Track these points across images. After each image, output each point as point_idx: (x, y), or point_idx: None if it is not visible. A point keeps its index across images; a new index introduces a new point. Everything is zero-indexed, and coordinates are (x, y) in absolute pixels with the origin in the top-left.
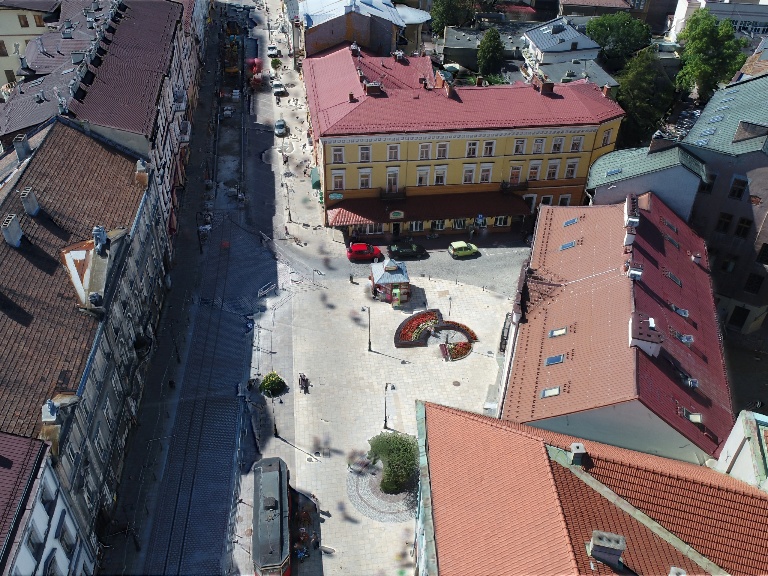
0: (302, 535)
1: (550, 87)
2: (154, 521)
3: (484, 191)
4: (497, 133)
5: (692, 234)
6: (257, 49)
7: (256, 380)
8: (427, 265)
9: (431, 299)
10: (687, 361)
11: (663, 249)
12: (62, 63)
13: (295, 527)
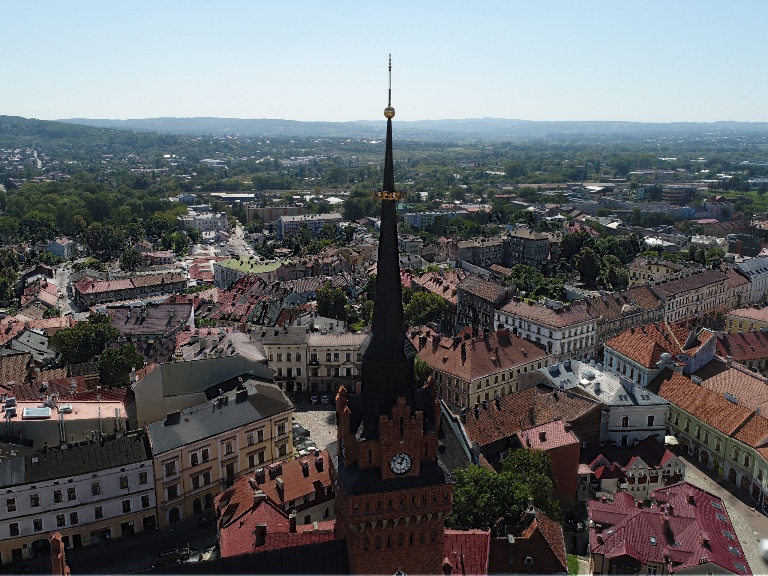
0: None
1: None
2: None
3: None
4: None
5: None
6: None
7: None
8: None
9: None
10: None
11: None
12: None
13: None
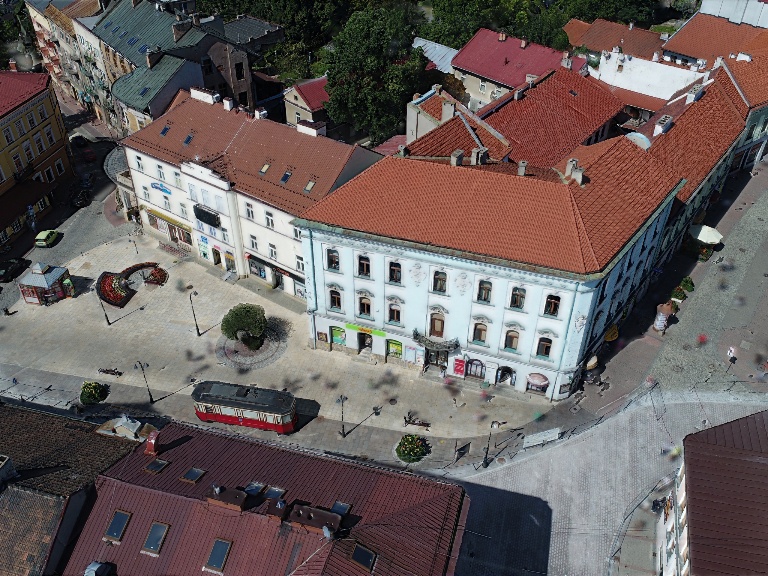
0: None
1: None
2: None
3: (6, 191)
4: None
5: None
6: None
7: (75, 405)
8: None
9: (86, 274)
10: None
11: None
12: None
13: None
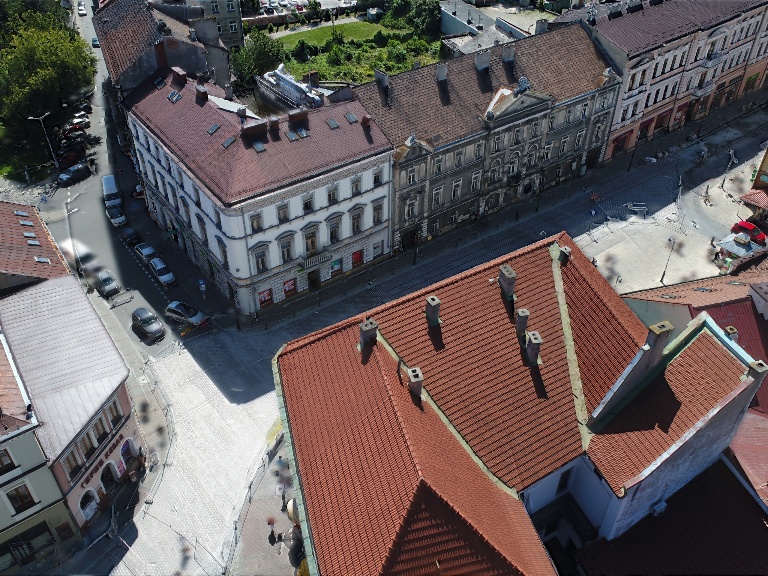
0: None
1: None
2: (434, 260)
3: None
4: None
5: None
6: None
7: None
8: None
9: None
10: None
11: None
12: None
13: None
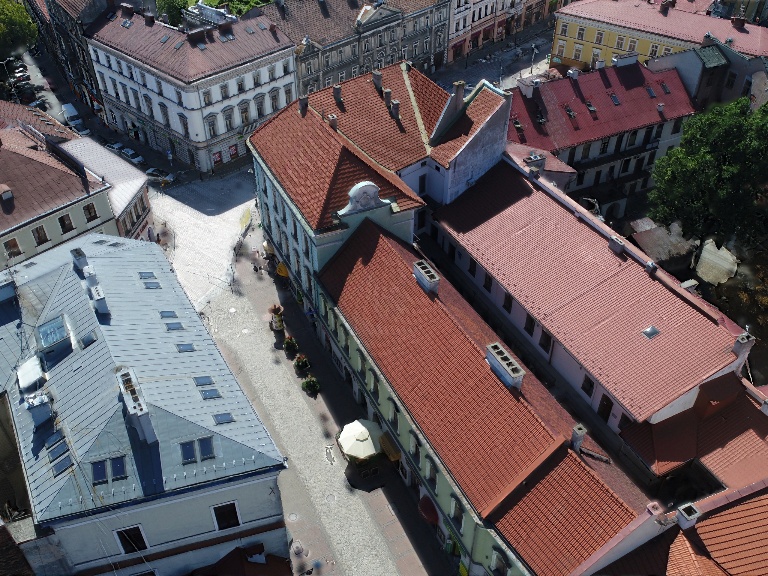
0: None
1: (742, 22)
2: None
3: None
4: (674, 42)
5: (686, 103)
6: None
7: None
8: None
9: None
10: (557, 118)
11: (631, 88)
12: None
13: None
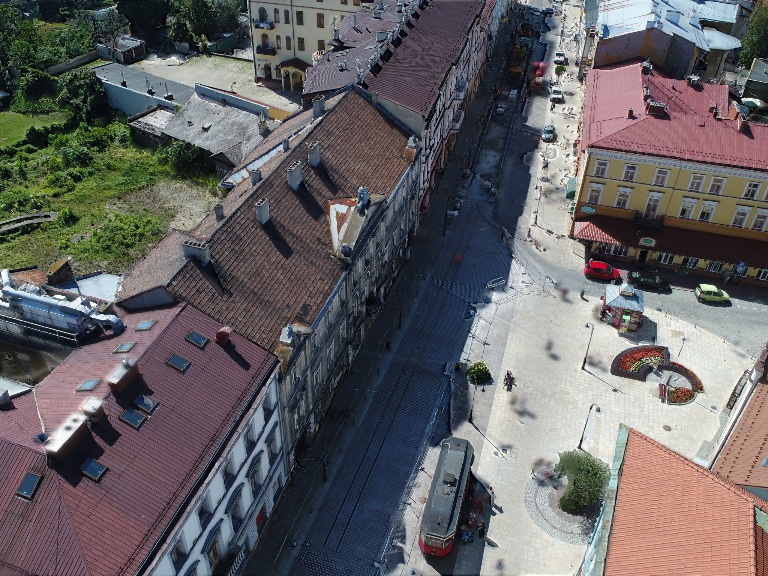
0: (471, 520)
1: None
2: (344, 460)
3: (753, 238)
4: None
5: None
6: (545, 54)
7: (464, 364)
8: (667, 300)
9: (662, 336)
10: None
11: None
12: (367, 39)
13: (466, 510)
